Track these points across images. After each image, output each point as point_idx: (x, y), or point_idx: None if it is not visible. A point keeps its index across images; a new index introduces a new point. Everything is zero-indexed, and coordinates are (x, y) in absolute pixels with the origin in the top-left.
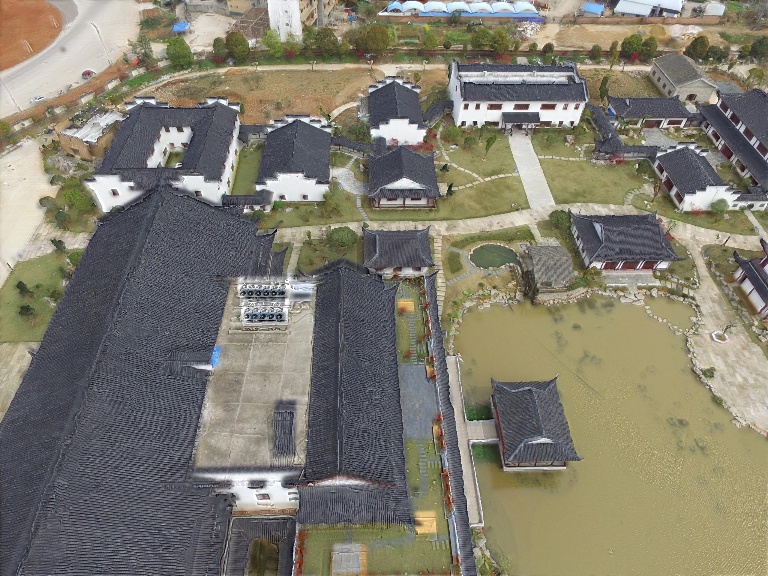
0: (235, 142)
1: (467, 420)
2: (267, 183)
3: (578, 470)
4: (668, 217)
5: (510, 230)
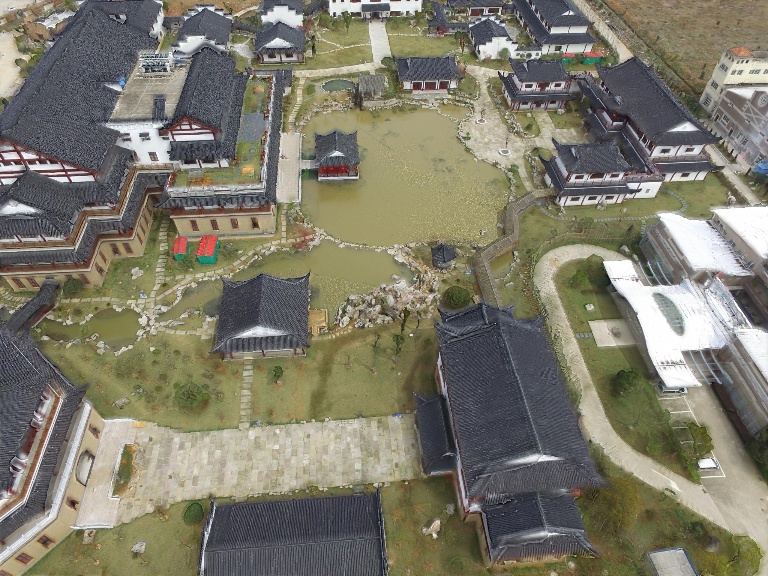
0: (160, 26)
1: (300, 160)
2: (180, 45)
3: (367, 181)
4: (471, 64)
5: (355, 73)
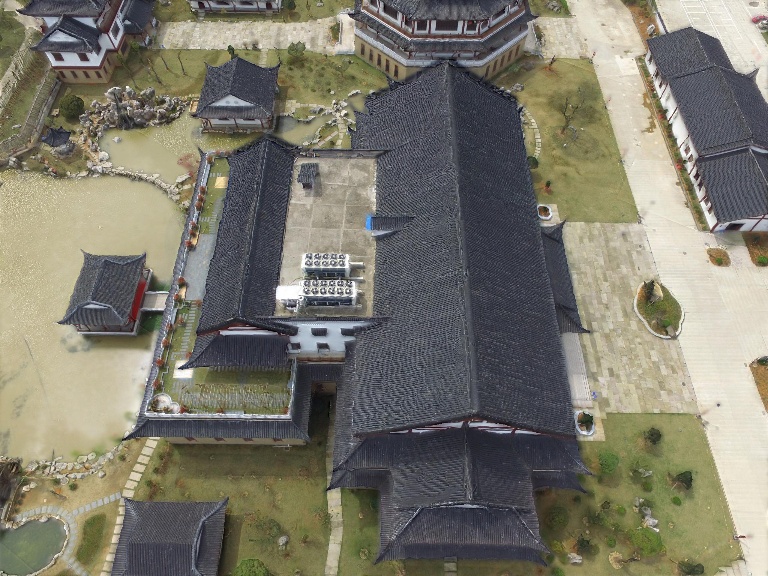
0: None
1: None
2: None
3: None
4: None
5: None
